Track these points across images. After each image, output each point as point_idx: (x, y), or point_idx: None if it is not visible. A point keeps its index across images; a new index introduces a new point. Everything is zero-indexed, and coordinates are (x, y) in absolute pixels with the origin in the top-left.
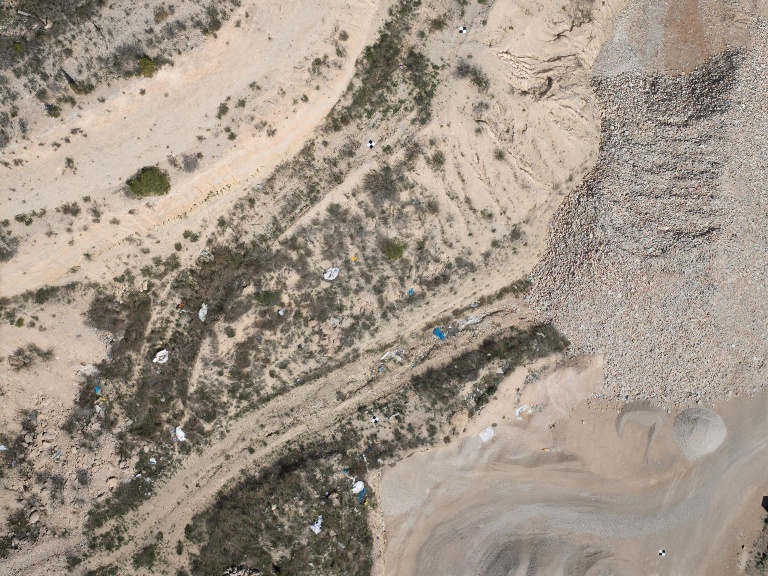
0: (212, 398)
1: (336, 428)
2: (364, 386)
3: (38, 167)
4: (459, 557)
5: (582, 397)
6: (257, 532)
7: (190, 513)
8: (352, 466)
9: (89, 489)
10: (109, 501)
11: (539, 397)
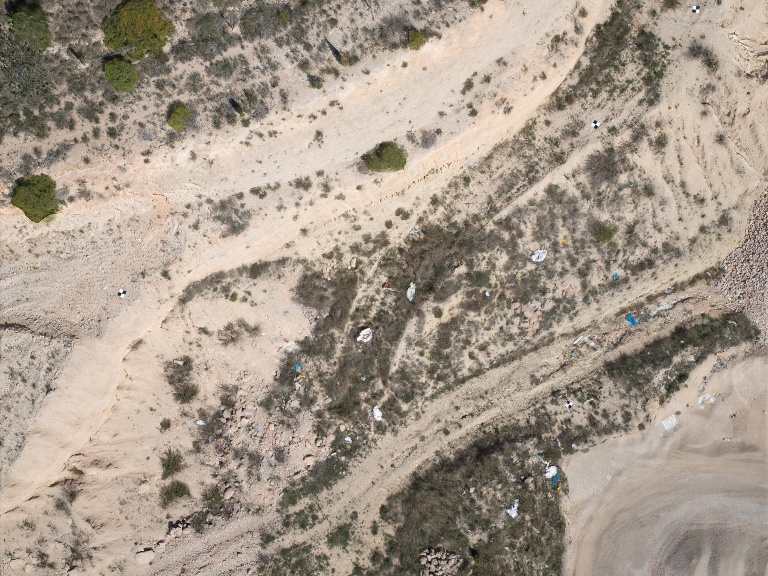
0: (411, 378)
1: (530, 412)
2: (557, 370)
3: (288, 139)
4: (639, 545)
5: (765, 387)
6: (455, 514)
7: (385, 493)
8: (547, 451)
9: (285, 466)
10: (304, 479)
11: (723, 386)
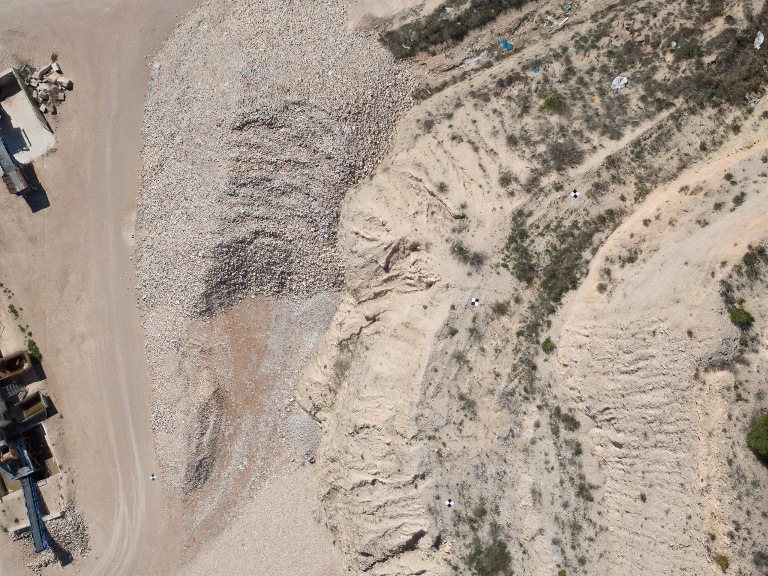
0: None
1: None
2: None
3: None
4: None
5: None
6: None
7: None
8: None
9: None
10: None
11: None
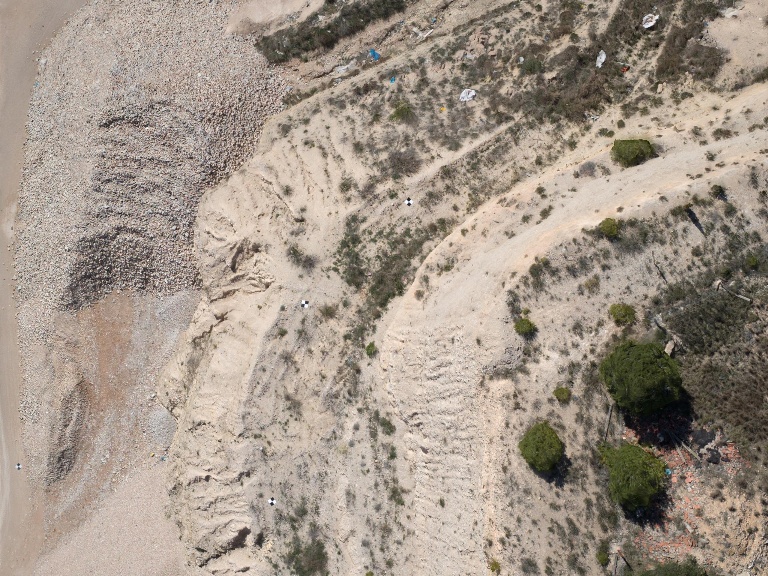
0: None
1: None
2: (452, 2)
3: None
4: None
5: (252, 4)
6: None
7: None
8: None
9: None
10: None
11: (291, 3)
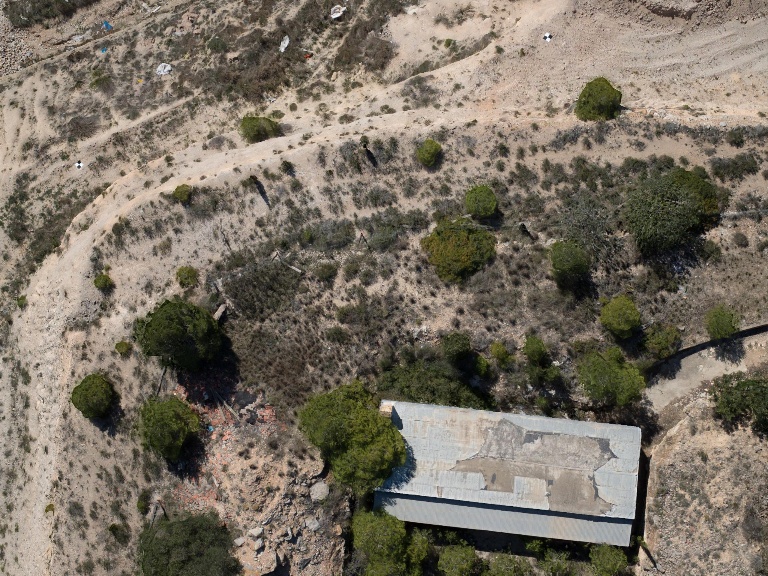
0: None
1: None
2: None
3: None
4: None
5: None
6: None
7: None
8: None
9: None
10: None
11: None
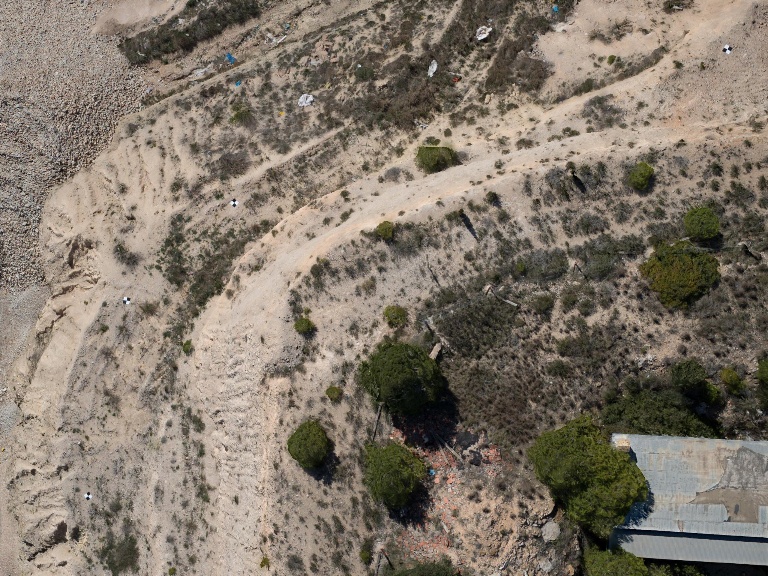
0: None
1: None
2: (304, 10)
3: None
4: None
5: (122, 5)
6: None
7: None
8: None
9: None
10: None
11: (159, 6)
